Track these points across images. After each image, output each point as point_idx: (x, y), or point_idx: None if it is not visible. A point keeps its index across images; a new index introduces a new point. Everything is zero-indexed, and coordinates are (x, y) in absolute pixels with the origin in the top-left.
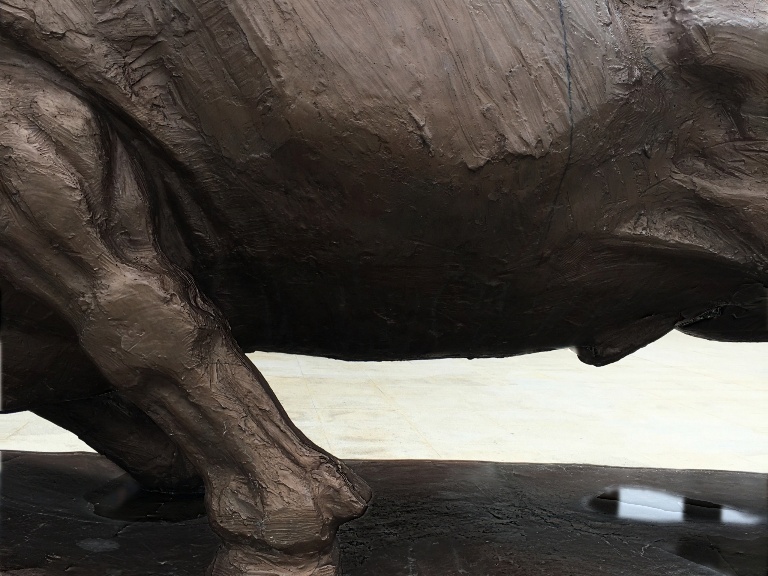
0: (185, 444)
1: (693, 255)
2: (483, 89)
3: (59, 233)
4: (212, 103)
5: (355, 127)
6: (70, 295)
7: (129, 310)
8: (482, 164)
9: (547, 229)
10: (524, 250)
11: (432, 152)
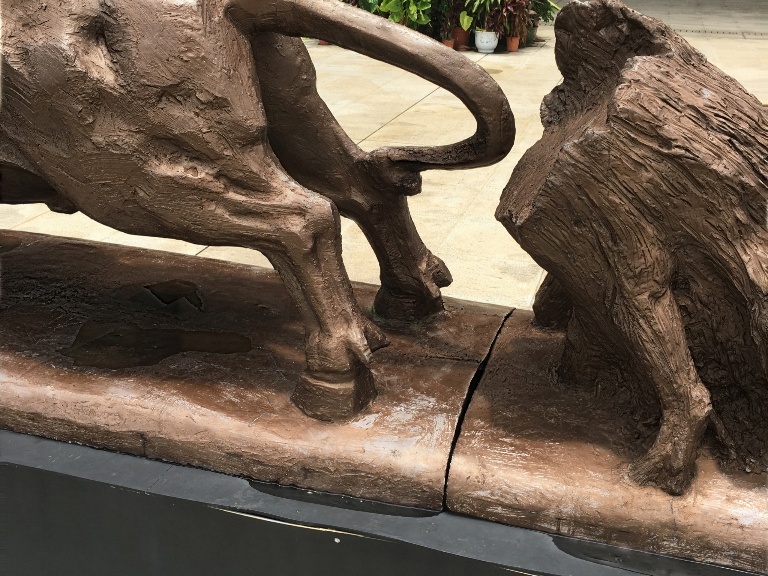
0: None
1: (18, 168)
2: None
3: None
4: None
5: None
6: None
7: None
8: None
9: None
10: None
11: None
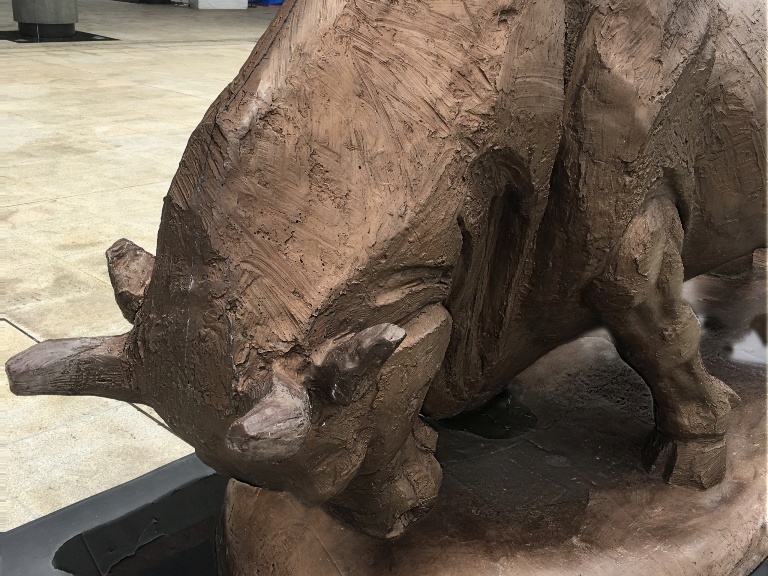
0: (672, 394)
1: None
2: None
3: None
4: None
5: None
6: (656, 331)
7: (688, 333)
8: None
9: None
10: None
11: None
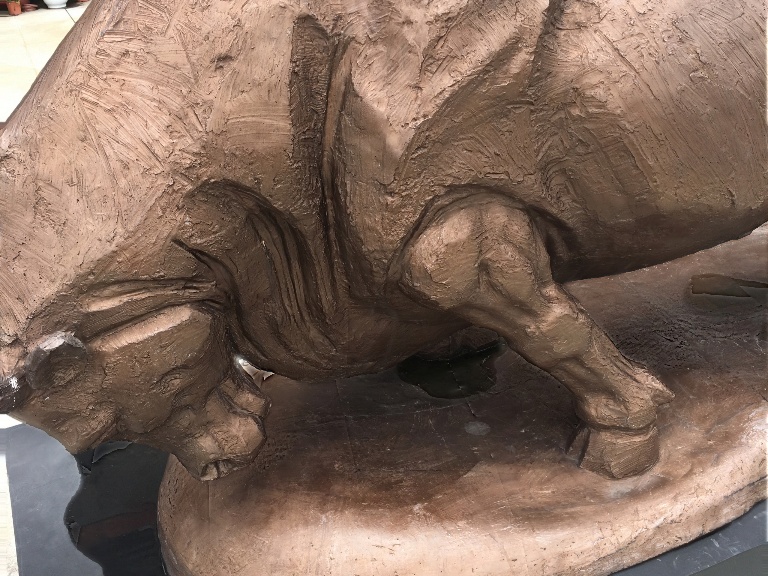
0: (572, 384)
1: None
2: (765, 161)
3: (523, 301)
4: (599, 194)
5: (697, 203)
6: (518, 327)
7: (559, 331)
8: (759, 205)
9: (766, 213)
10: (749, 225)
11: (735, 207)
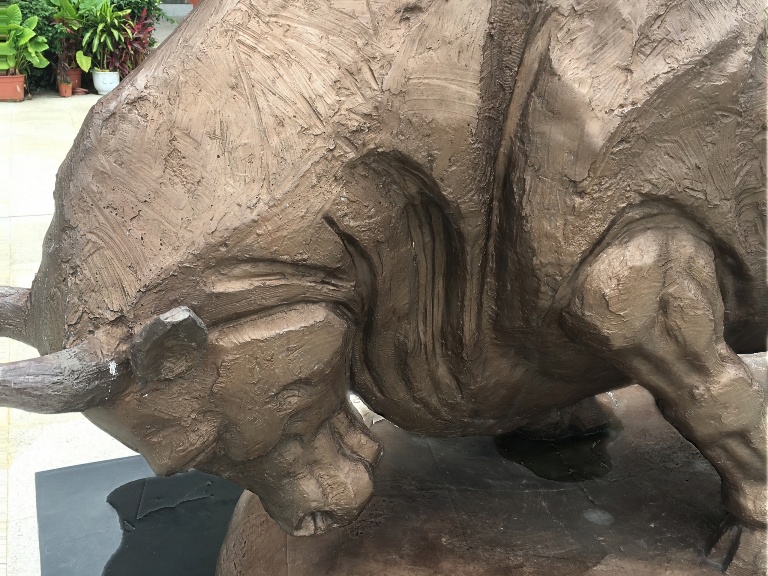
0: (730, 468)
1: None
2: None
3: (699, 353)
4: None
5: None
6: (683, 387)
7: (732, 397)
8: None
9: None
10: None
11: None
